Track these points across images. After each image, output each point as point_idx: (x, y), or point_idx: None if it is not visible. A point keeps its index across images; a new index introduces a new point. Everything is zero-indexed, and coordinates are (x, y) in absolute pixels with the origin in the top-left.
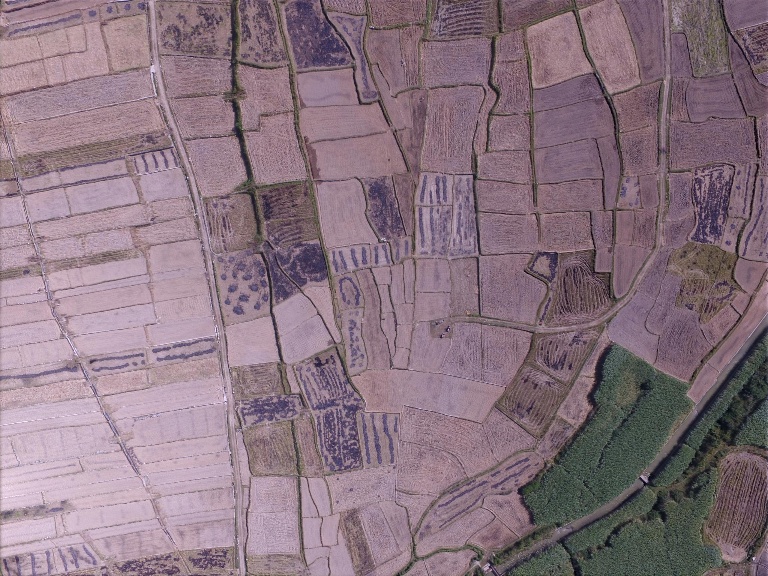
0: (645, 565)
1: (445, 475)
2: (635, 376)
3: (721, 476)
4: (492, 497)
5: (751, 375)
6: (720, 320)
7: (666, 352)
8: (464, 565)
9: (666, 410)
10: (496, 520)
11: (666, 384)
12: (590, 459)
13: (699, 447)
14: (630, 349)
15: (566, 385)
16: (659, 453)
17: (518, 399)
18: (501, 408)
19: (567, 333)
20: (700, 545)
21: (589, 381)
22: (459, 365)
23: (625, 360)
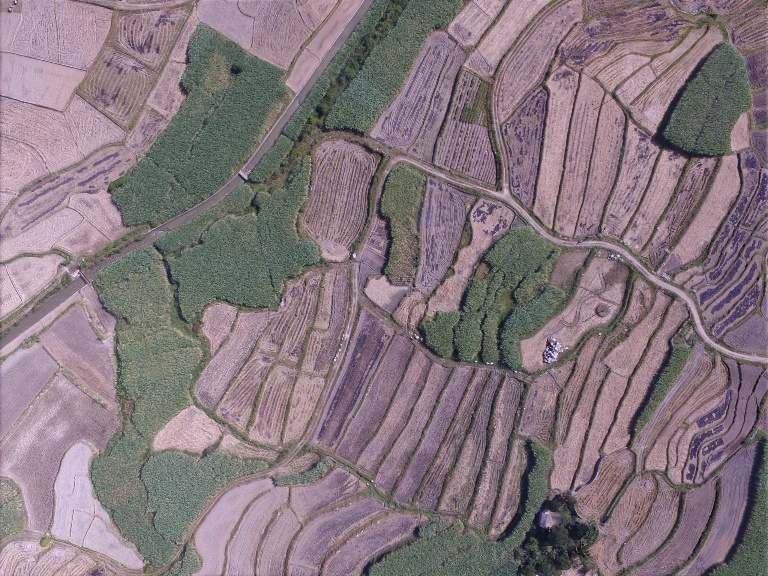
0: (238, 262)
1: (25, 170)
2: (225, 59)
3: (317, 166)
4: (79, 196)
5: (348, 58)
6: (319, 2)
7: (262, 36)
8: (51, 272)
9: (259, 96)
10: (85, 222)
11: (257, 66)
12: (179, 149)
13: (298, 138)
14: (223, 32)
15: (154, 70)
16: (260, 148)
17: (101, 85)
18: (83, 94)
19: (152, 12)
20: (294, 239)
21: (180, 67)
22: (32, 44)
23: (213, 40)
